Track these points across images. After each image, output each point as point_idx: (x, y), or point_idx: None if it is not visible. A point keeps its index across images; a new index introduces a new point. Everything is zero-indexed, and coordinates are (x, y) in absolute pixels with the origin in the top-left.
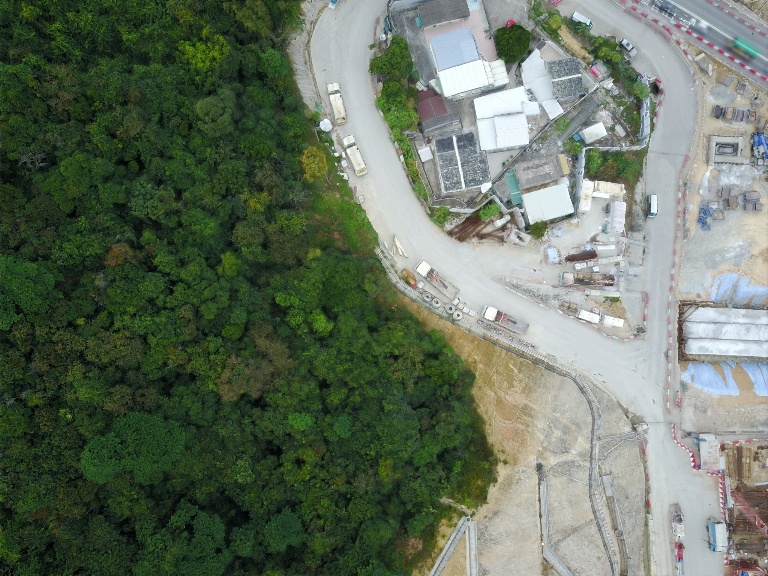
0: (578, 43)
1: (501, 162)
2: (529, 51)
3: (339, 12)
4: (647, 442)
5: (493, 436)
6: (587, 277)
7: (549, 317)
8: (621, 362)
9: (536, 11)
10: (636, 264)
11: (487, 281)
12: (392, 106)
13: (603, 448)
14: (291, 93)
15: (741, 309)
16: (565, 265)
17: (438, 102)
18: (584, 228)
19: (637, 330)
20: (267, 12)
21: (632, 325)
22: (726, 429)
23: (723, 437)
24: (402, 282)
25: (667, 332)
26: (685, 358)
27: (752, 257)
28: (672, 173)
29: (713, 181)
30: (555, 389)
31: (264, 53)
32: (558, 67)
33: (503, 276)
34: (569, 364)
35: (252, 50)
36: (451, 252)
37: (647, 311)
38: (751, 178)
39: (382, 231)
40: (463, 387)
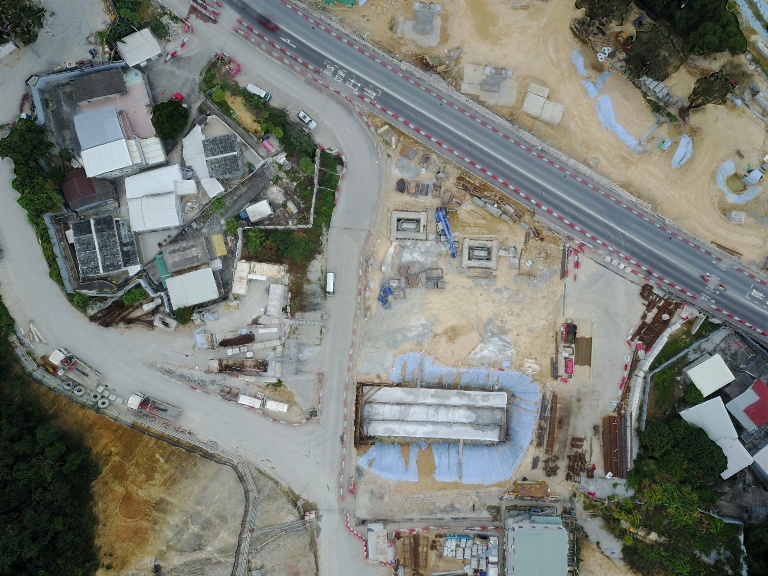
0: (251, 116)
1: (157, 242)
2: (194, 126)
3: None
4: (320, 530)
5: (105, 537)
6: (238, 363)
7: (210, 402)
8: (292, 447)
9: (208, 83)
10: (312, 344)
11: (138, 366)
12: (27, 188)
13: (258, 540)
14: None
15: (430, 389)
16: (219, 350)
17: (85, 182)
18: (245, 310)
19: (310, 414)
20: None
21: (304, 408)
22: (404, 516)
23: (400, 525)
24: (40, 370)
25: (344, 415)
26: (364, 441)
27: (435, 336)
28: (355, 249)
29: (396, 258)
30: (207, 479)
31: None
32: (212, 145)
33: (154, 361)
34: (234, 450)
35: None
36: (96, 337)
37: (323, 393)
38: (436, 254)
39: (19, 317)
40: (54, 491)
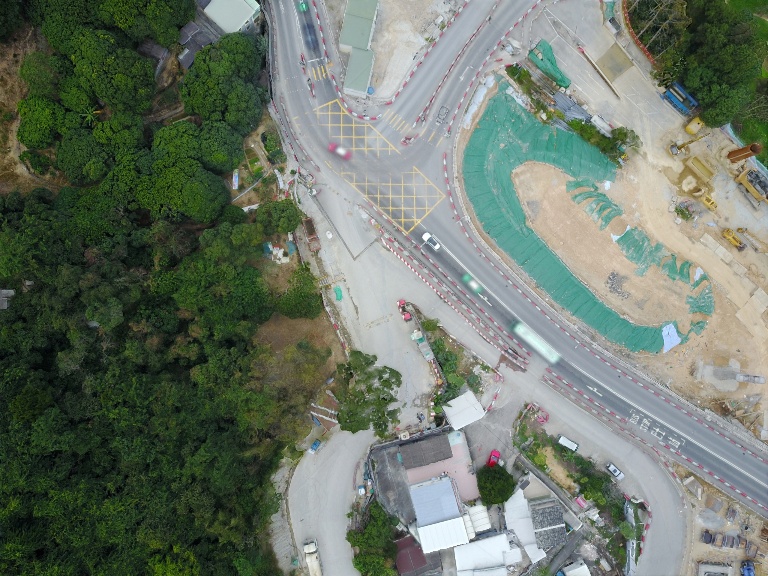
0: (564, 470)
1: None
2: (513, 485)
3: (319, 456)
4: None
5: None
6: None
7: None
8: None
9: (521, 436)
10: None
11: None
12: (369, 568)
13: None
14: (265, 571)
15: None
16: None
17: (417, 553)
18: None
19: None
20: (241, 515)
21: None
22: None
23: None
24: None
25: None
26: None
27: None
28: None
29: None
30: None
31: (237, 552)
32: (541, 517)
33: None
34: None
35: (224, 558)
36: None
37: None
38: None
39: None
40: None
